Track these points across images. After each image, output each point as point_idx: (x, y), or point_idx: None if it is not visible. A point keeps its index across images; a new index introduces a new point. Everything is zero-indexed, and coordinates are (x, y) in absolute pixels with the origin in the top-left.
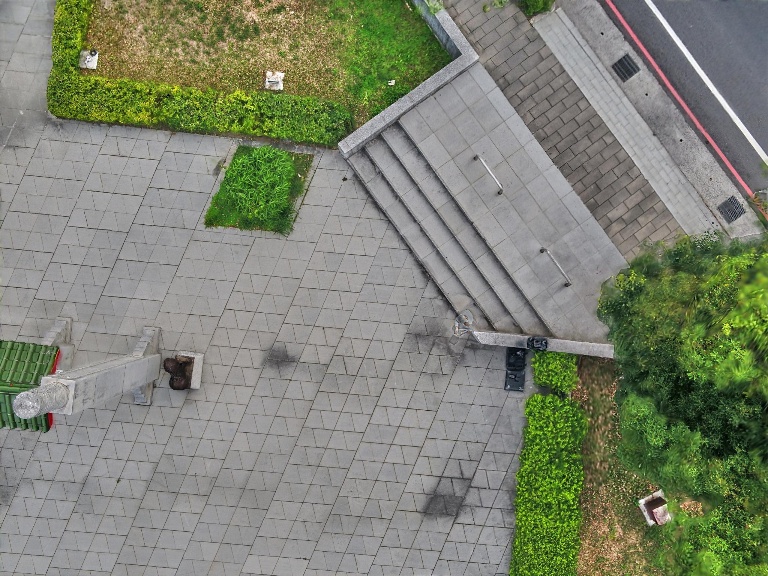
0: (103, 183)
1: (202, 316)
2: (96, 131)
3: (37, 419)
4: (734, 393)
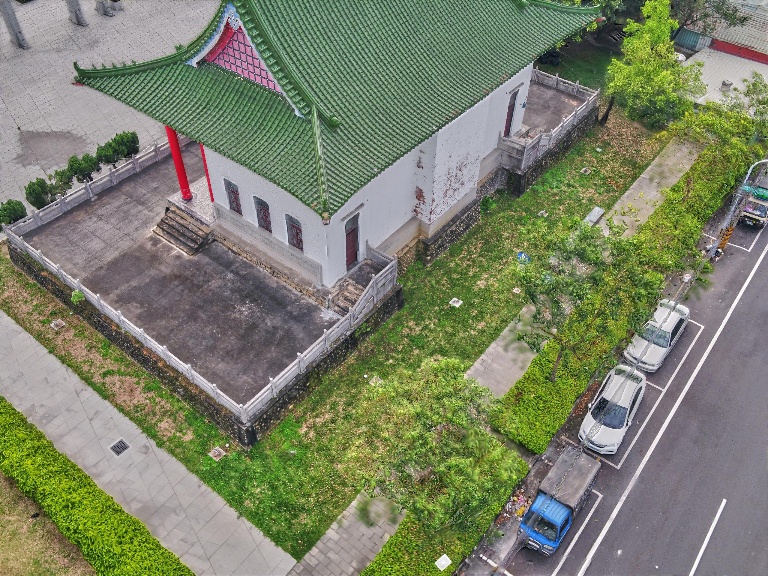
0: (50, 3)
1: None
2: (37, 0)
3: None
4: None
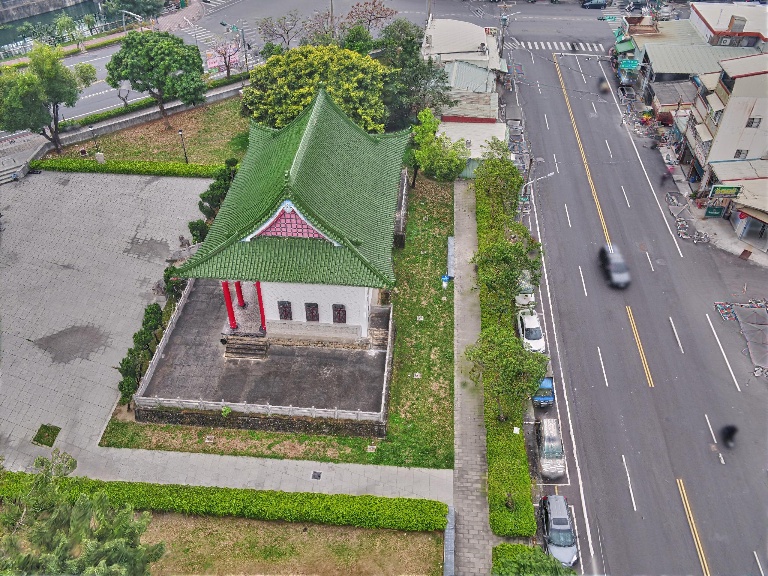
0: None
1: None
2: None
3: None
4: (7, 92)
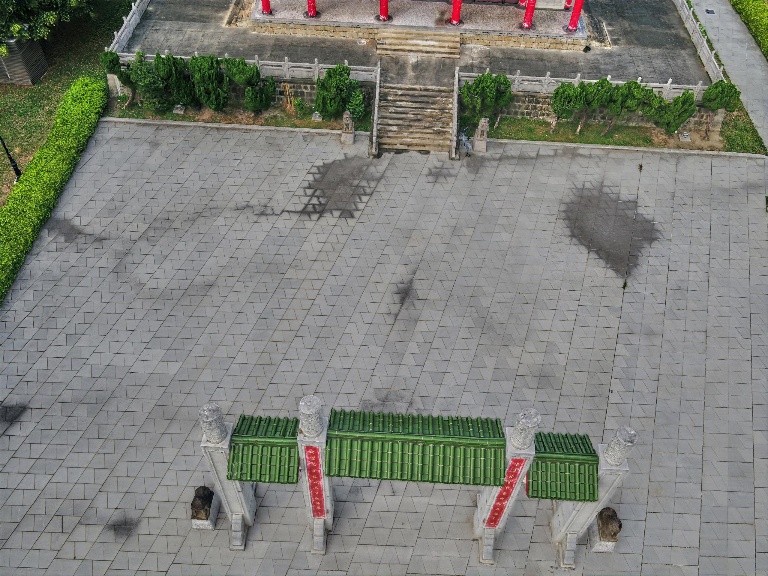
0: None
1: (190, 564)
2: None
3: None
4: None
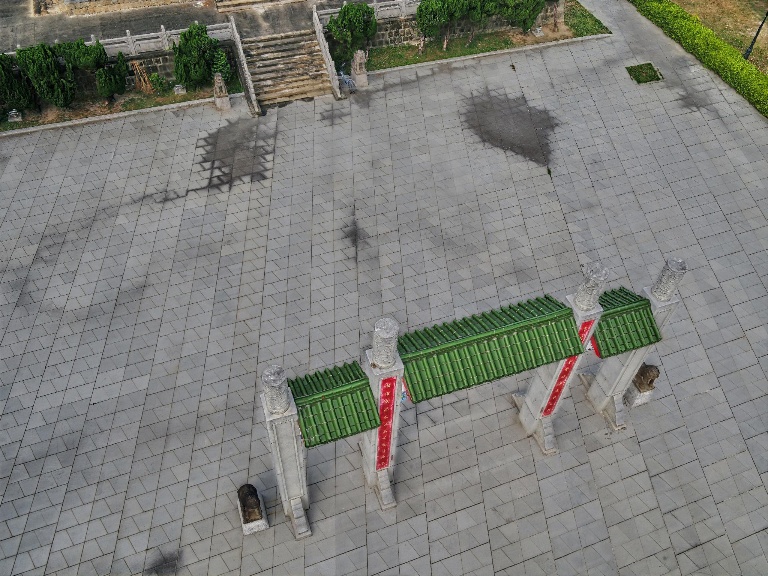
0: None
1: (260, 572)
2: None
3: (298, 385)
4: None
